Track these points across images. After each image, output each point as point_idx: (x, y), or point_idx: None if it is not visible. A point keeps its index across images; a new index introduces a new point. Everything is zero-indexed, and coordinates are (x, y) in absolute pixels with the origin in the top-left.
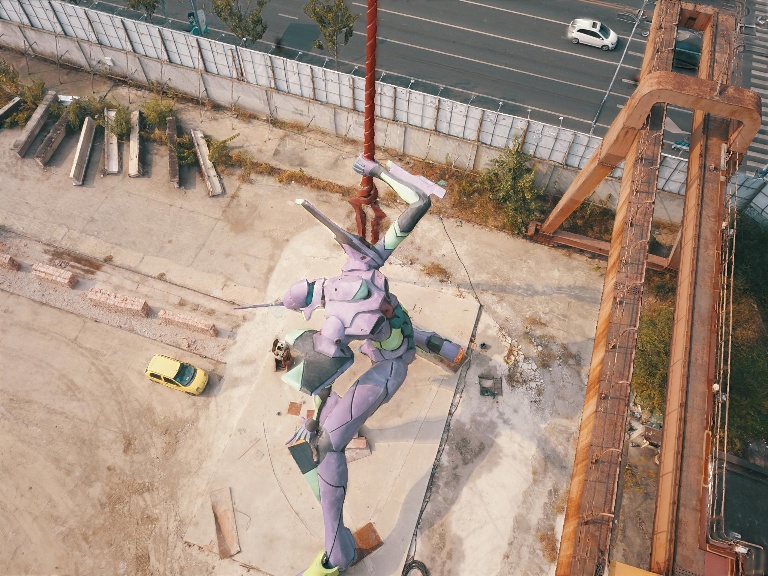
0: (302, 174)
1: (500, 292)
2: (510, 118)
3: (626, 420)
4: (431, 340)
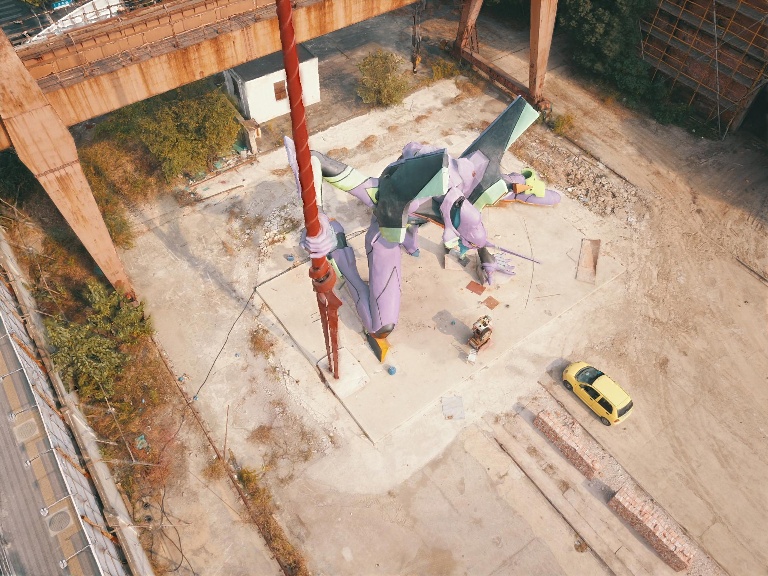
0: None
1: (226, 289)
2: None
3: None
4: (343, 247)
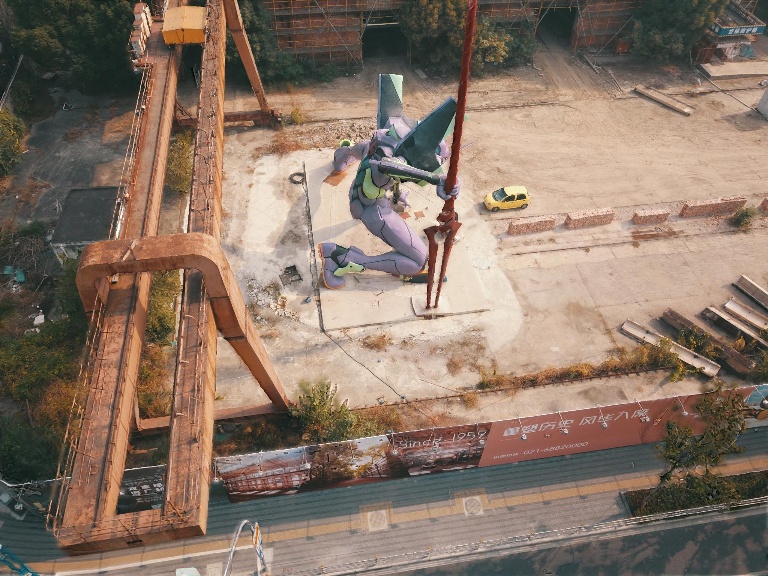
0: (569, 368)
1: (310, 350)
2: (374, 439)
3: None
4: (347, 250)
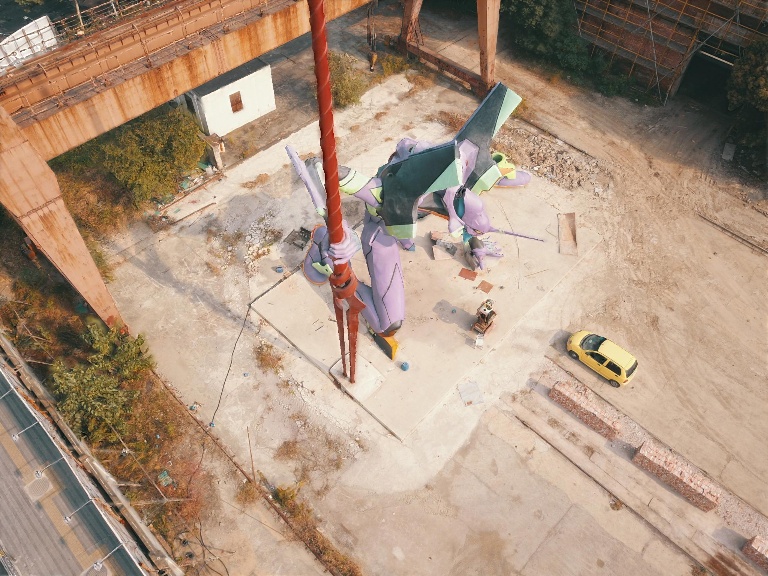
0: None
1: (220, 310)
2: None
3: None
4: None
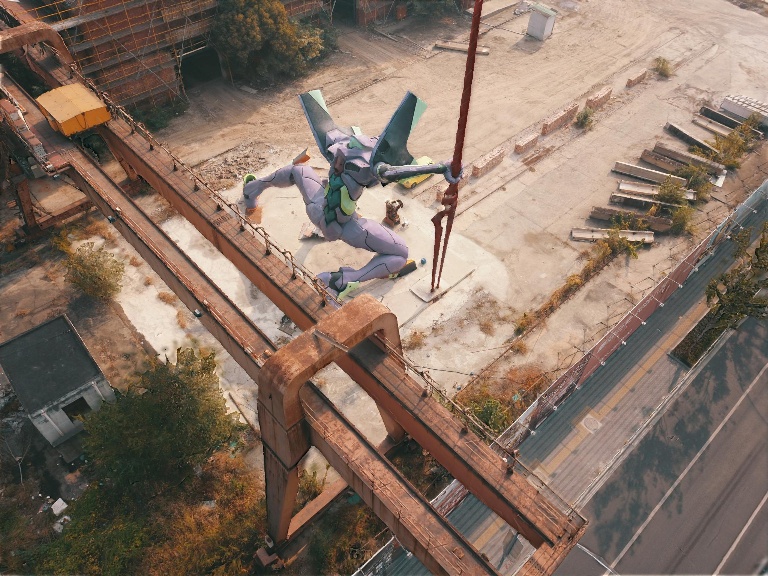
0: (569, 284)
1: None
2: None
3: (153, 171)
4: (340, 273)
